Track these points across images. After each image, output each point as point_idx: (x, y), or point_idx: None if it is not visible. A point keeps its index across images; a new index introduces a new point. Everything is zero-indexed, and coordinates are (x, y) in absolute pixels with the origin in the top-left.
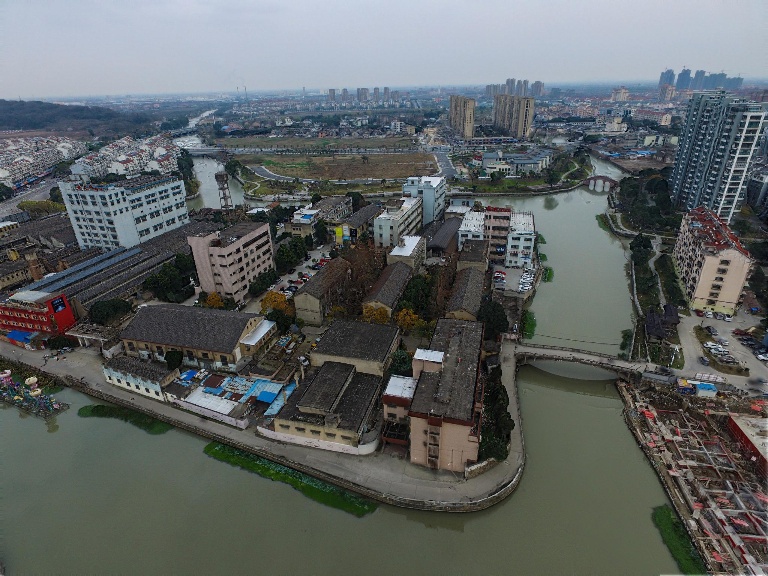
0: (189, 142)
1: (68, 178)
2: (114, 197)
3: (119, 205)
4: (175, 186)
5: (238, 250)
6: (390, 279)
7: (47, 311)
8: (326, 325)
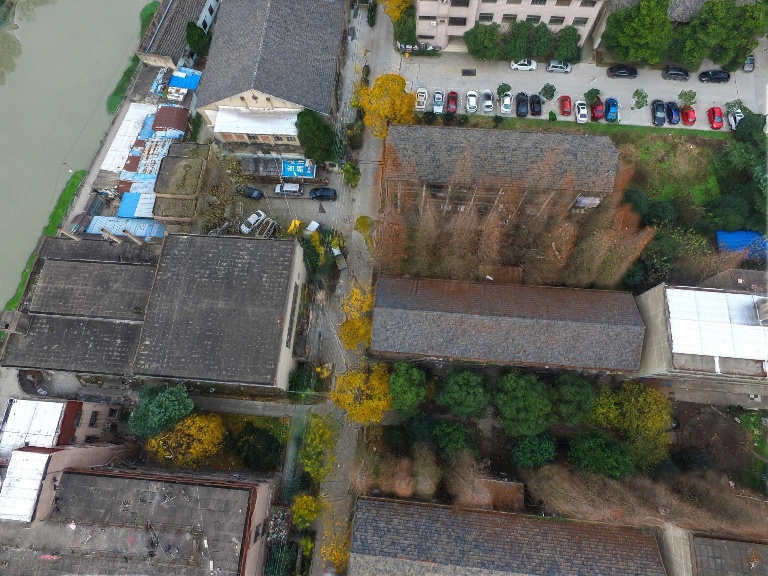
0: None
1: None
2: None
3: None
4: None
5: None
6: (502, 322)
7: None
8: (390, 221)
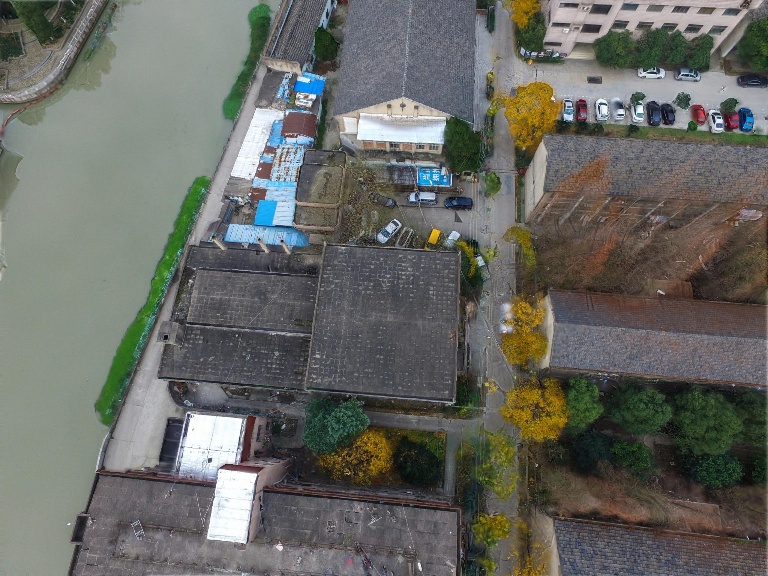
0: None
1: None
2: None
3: None
4: None
5: None
6: (690, 339)
7: None
8: None
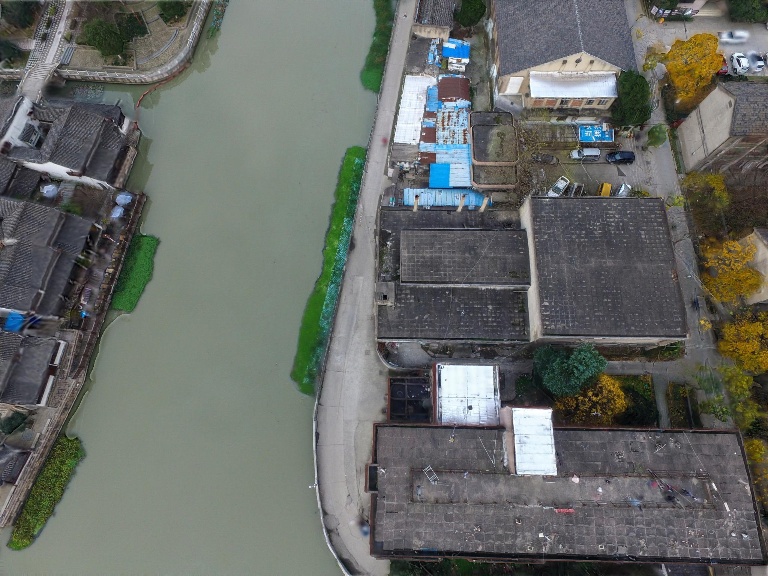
0: None
1: None
2: None
3: None
4: None
5: None
6: None
7: None
8: None
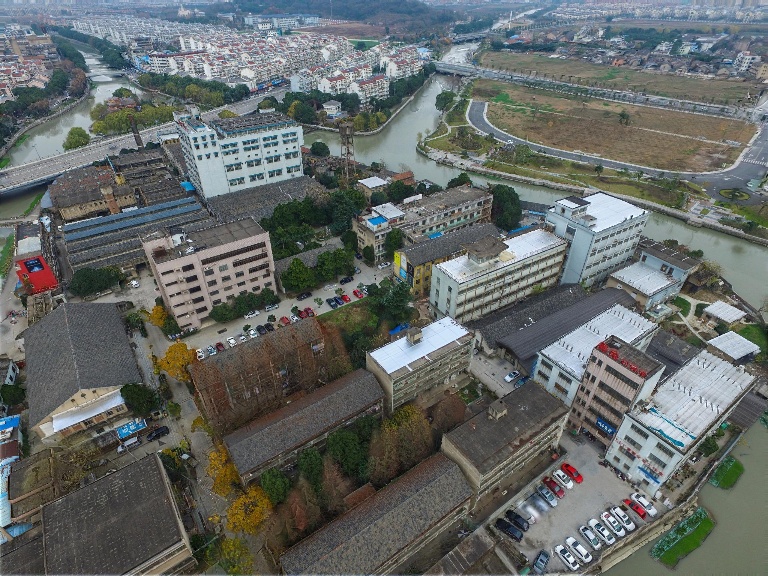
0: (454, 54)
1: (185, 108)
2: (201, 140)
3: (206, 149)
4: (289, 133)
5: (190, 267)
6: (306, 411)
7: (19, 270)
8: None
